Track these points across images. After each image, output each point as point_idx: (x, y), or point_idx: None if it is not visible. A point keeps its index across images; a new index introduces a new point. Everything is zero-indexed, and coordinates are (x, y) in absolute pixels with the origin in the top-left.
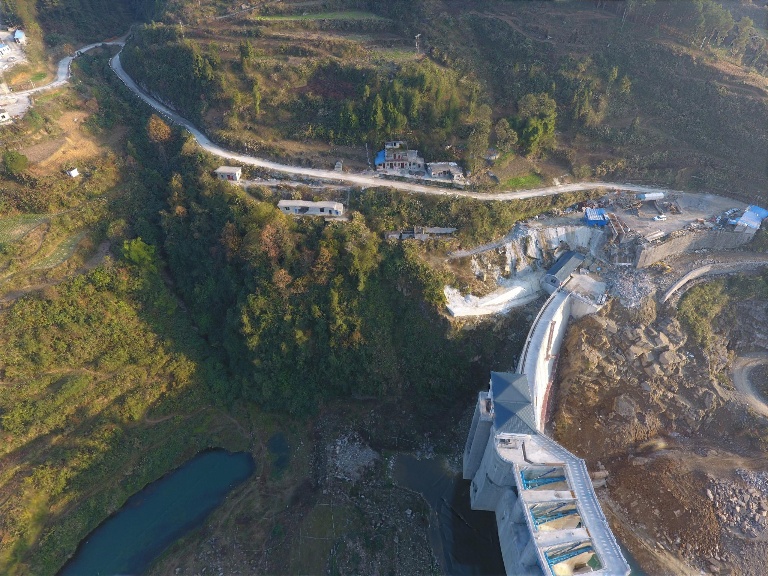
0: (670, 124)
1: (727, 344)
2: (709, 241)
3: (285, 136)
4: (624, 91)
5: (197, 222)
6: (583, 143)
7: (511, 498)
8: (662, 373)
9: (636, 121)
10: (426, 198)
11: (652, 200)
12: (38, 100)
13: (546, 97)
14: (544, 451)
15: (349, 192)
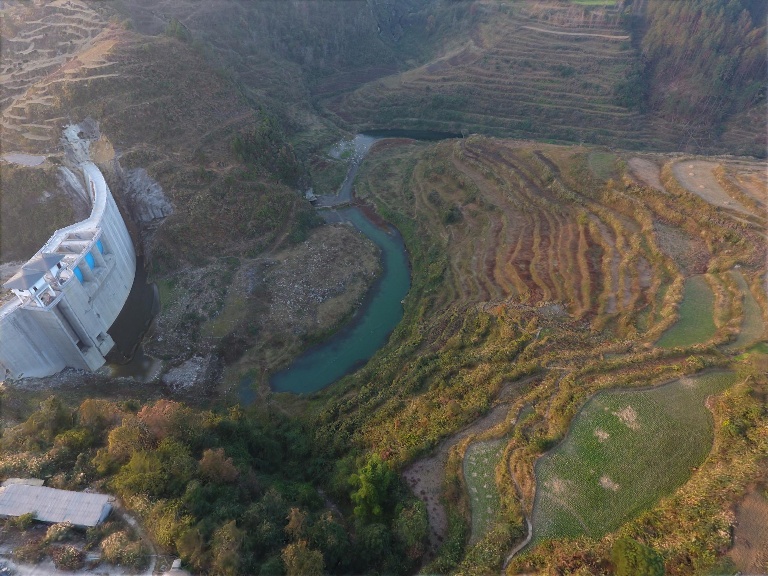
0: None
1: None
2: None
3: None
4: None
5: (266, 496)
6: None
7: (85, 286)
8: None
9: None
10: None
11: None
12: None
13: None
14: None
15: None
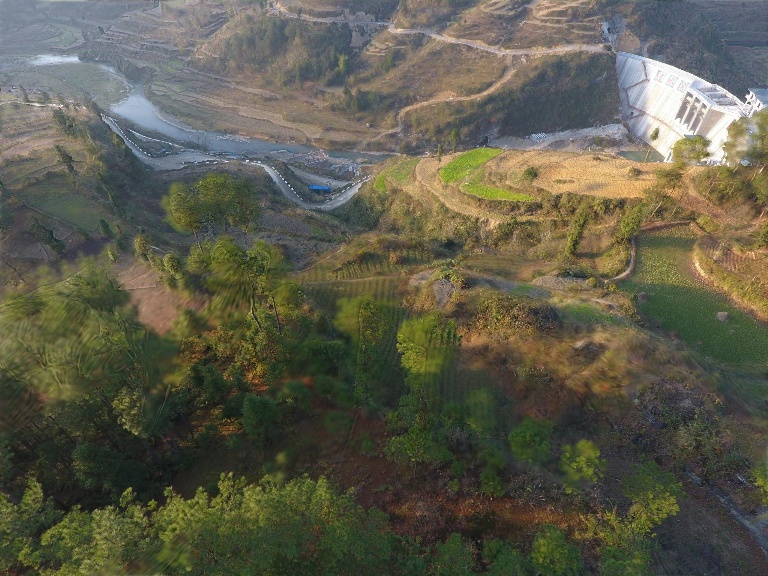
0: None
1: None
2: None
3: None
4: None
5: None
6: None
7: None
8: None
9: None
10: None
11: None
12: None
13: None
14: (730, 108)
15: None
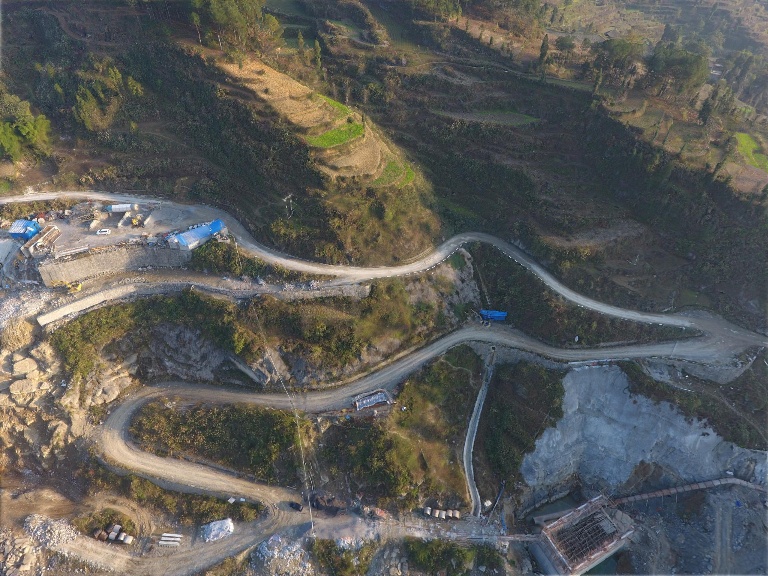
0: (182, 129)
1: (124, 372)
2: (151, 258)
3: None
4: (136, 93)
5: None
6: (86, 149)
7: None
8: (9, 404)
9: (131, 126)
10: None
11: (122, 212)
12: None
13: (6, 99)
14: None
15: None
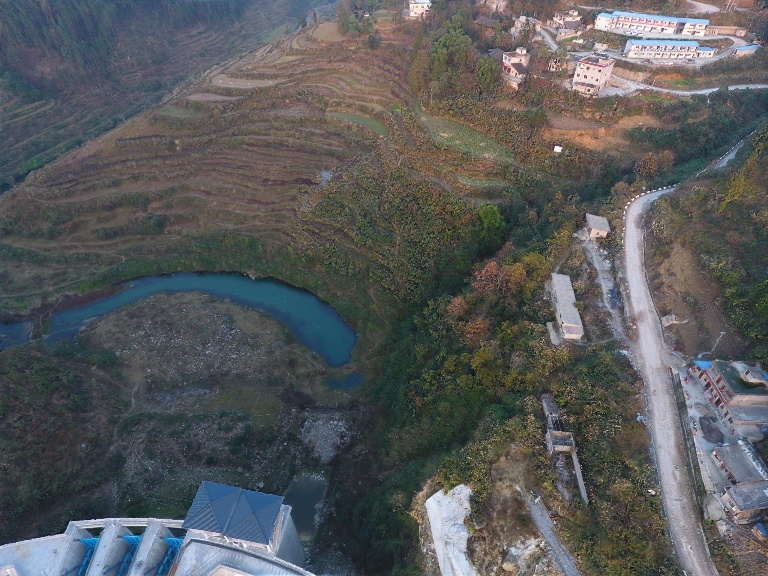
0: None
1: None
2: None
3: (699, 250)
4: None
5: (521, 230)
6: None
7: None
8: None
9: None
10: (636, 442)
11: None
12: (642, 96)
13: None
14: (192, 567)
15: (613, 339)
